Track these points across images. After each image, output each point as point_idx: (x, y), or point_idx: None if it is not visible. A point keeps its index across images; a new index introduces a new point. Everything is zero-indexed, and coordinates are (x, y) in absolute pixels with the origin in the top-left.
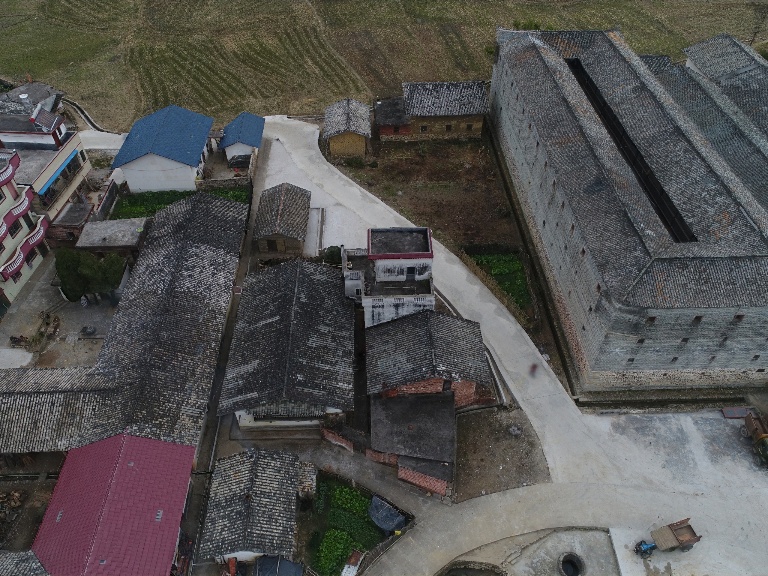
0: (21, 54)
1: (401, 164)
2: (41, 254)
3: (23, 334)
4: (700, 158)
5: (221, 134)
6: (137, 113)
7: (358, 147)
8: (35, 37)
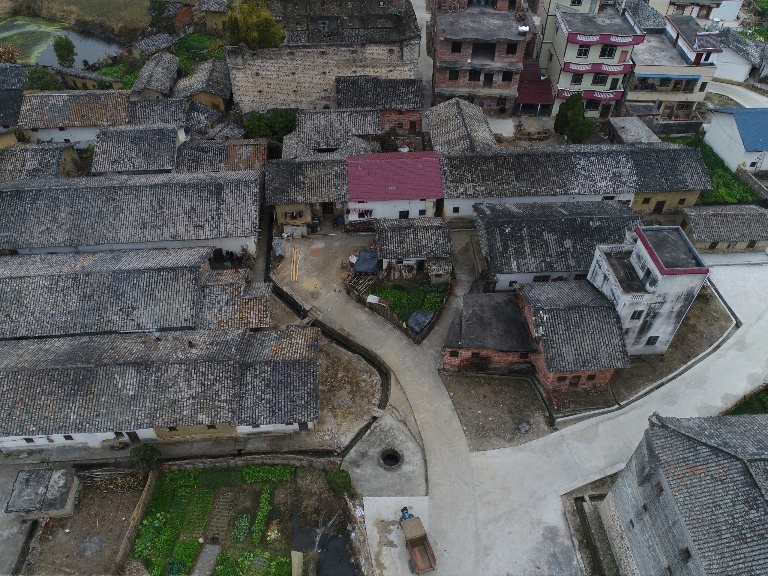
0: None
1: None
2: (601, 113)
3: (527, 127)
4: None
5: None
6: None
7: None
8: None
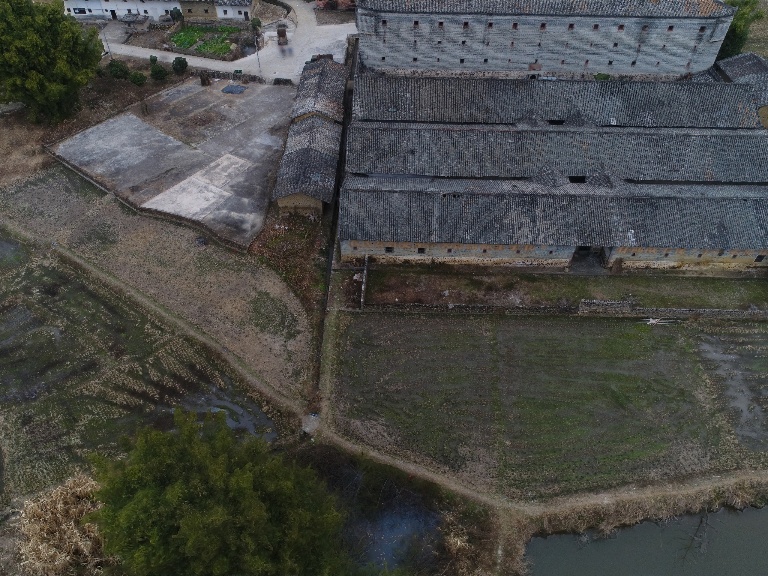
0: None
1: None
2: None
3: None
4: None
5: None
6: None
7: None
8: None
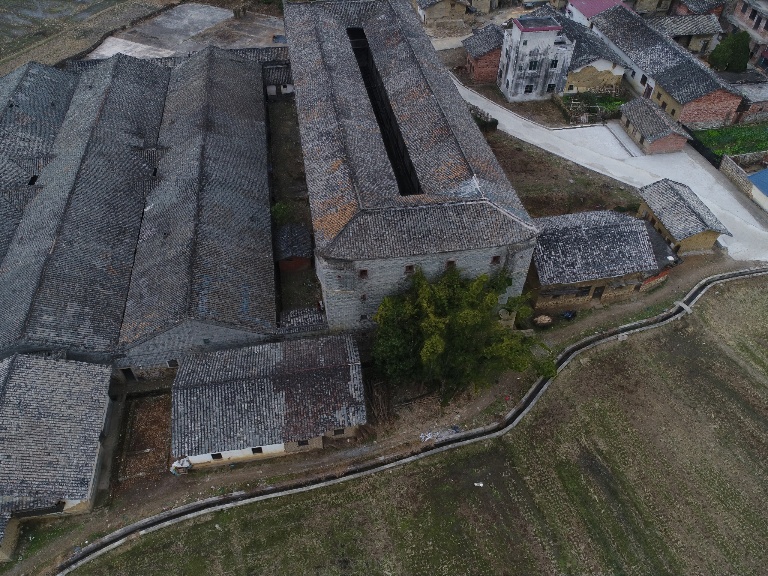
0: None
1: None
2: None
3: None
4: (323, 48)
5: None
6: None
7: None
8: None
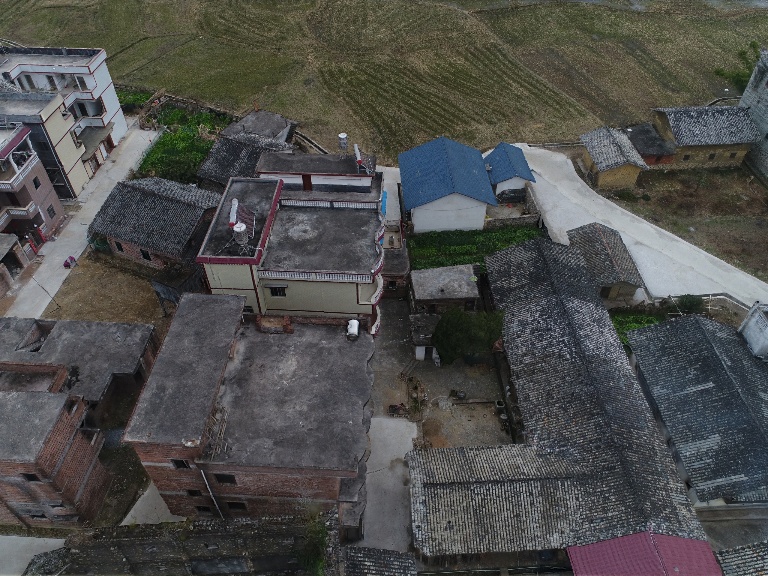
0: (207, 77)
1: (674, 196)
2: None
3: (394, 400)
4: None
5: (488, 167)
6: (367, 142)
7: (630, 179)
8: (211, 58)
